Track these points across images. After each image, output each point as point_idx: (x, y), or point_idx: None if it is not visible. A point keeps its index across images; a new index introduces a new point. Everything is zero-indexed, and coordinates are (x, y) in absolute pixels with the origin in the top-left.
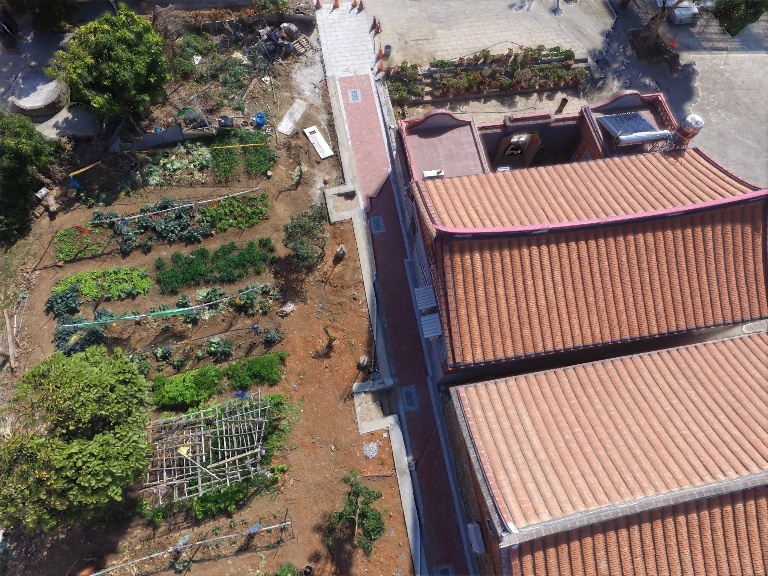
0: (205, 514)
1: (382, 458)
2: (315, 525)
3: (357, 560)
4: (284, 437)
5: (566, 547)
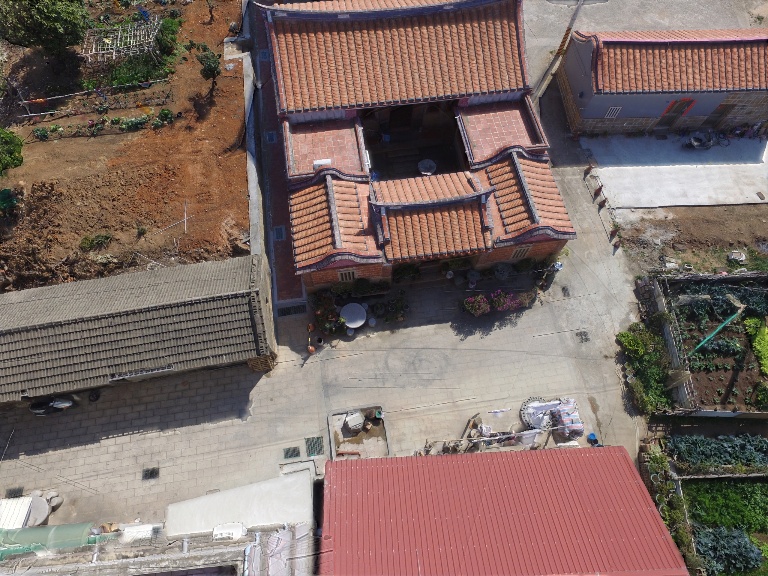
0: (120, 90)
1: (236, 70)
2: (187, 96)
3: (210, 112)
4: (175, 58)
5: (306, 36)
